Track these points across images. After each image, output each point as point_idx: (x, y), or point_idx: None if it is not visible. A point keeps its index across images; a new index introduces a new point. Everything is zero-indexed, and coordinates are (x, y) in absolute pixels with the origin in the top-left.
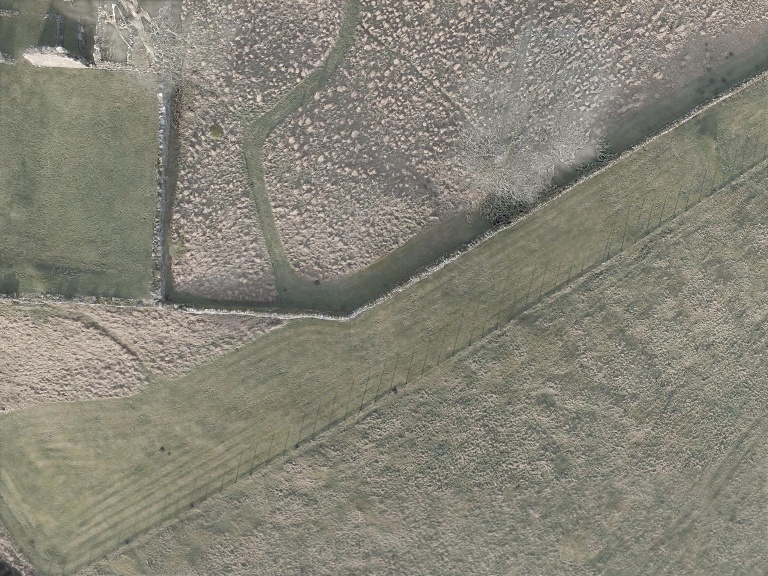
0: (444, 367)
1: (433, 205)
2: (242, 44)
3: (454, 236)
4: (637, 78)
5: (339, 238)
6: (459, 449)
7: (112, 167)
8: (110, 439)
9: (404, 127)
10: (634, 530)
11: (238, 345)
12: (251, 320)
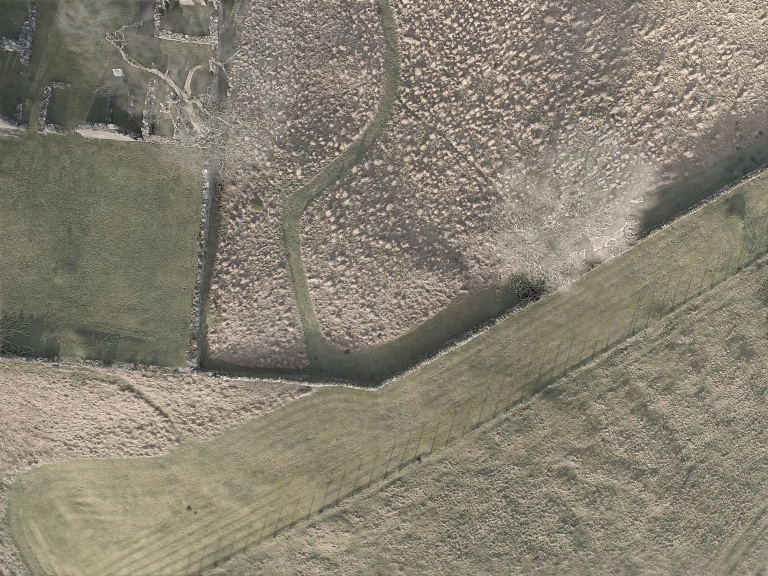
0: (468, 438)
1: (463, 279)
2: (284, 118)
3: (483, 309)
4: (667, 156)
5: (371, 309)
6: (480, 519)
7: (155, 237)
8: (139, 496)
9: (438, 201)
10: None
11: (268, 410)
12: (282, 387)
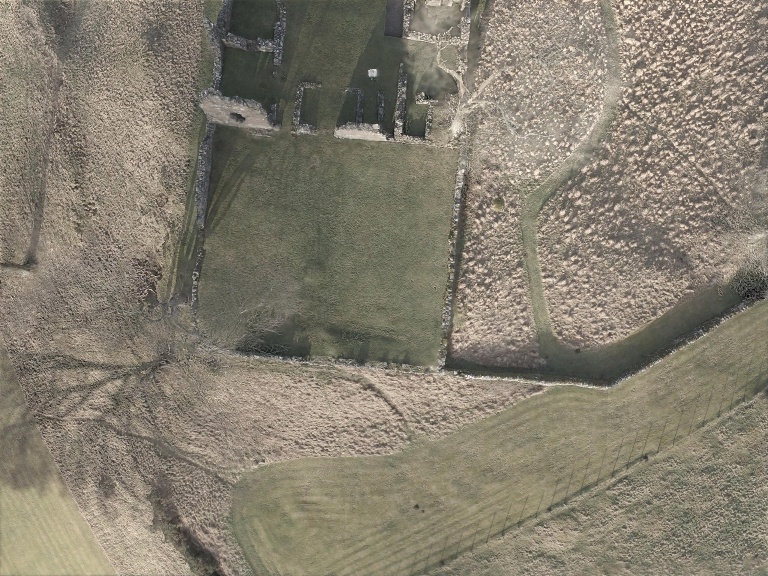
0: (694, 437)
1: (690, 278)
2: (521, 119)
3: (706, 309)
4: None
5: (602, 309)
6: (703, 518)
7: (404, 237)
8: (367, 495)
9: (661, 201)
10: None
11: (500, 409)
12: (514, 386)
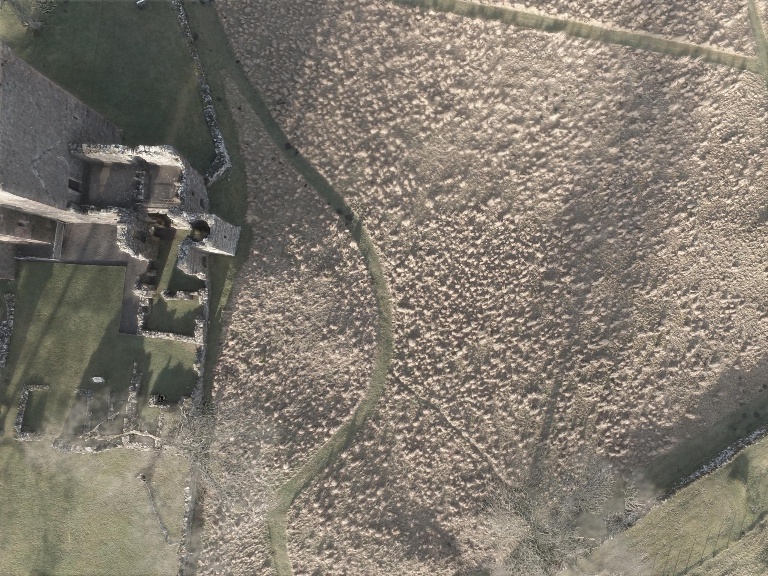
0: None
1: (456, 566)
2: (272, 409)
3: None
4: (669, 419)
5: None
6: None
7: (134, 547)
8: None
9: (430, 480)
10: None
11: None
12: None
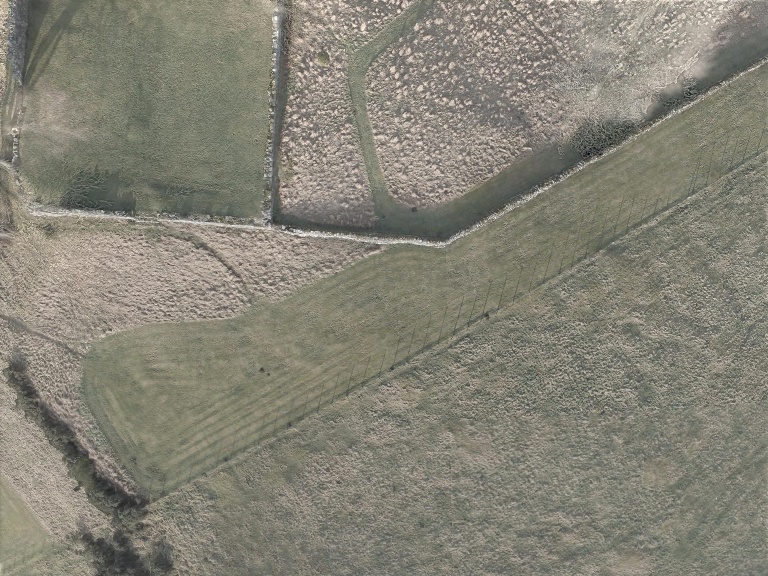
0: (535, 294)
1: (527, 136)
2: None
3: (546, 167)
4: (723, 16)
5: (436, 166)
6: (547, 375)
7: (225, 90)
8: (212, 360)
9: (498, 60)
10: (713, 459)
11: (338, 269)
12: (351, 245)
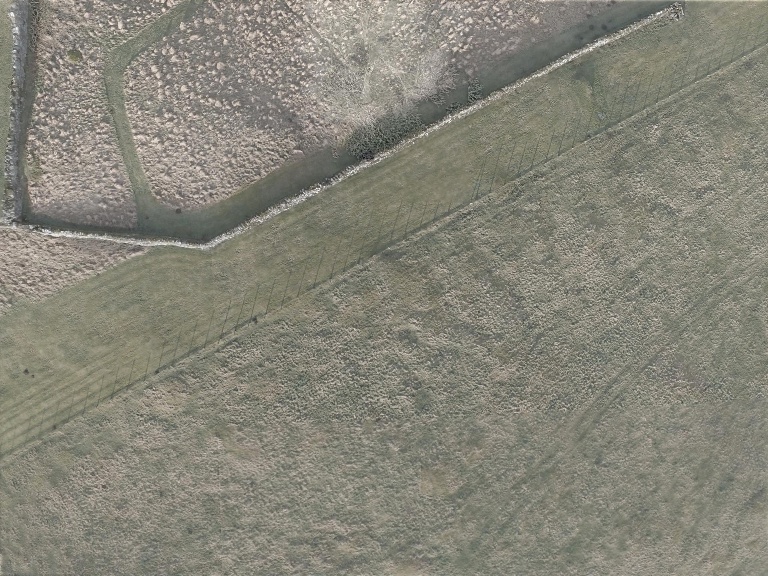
0: (304, 299)
1: (297, 138)
2: None
3: (319, 170)
4: (513, 21)
5: (201, 167)
6: (319, 380)
7: None
8: None
9: (272, 61)
10: (496, 468)
11: (99, 270)
12: (112, 246)
